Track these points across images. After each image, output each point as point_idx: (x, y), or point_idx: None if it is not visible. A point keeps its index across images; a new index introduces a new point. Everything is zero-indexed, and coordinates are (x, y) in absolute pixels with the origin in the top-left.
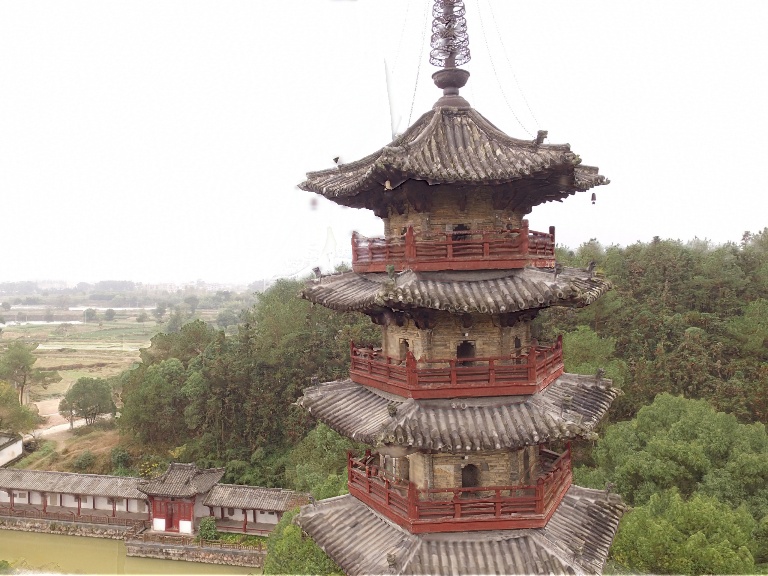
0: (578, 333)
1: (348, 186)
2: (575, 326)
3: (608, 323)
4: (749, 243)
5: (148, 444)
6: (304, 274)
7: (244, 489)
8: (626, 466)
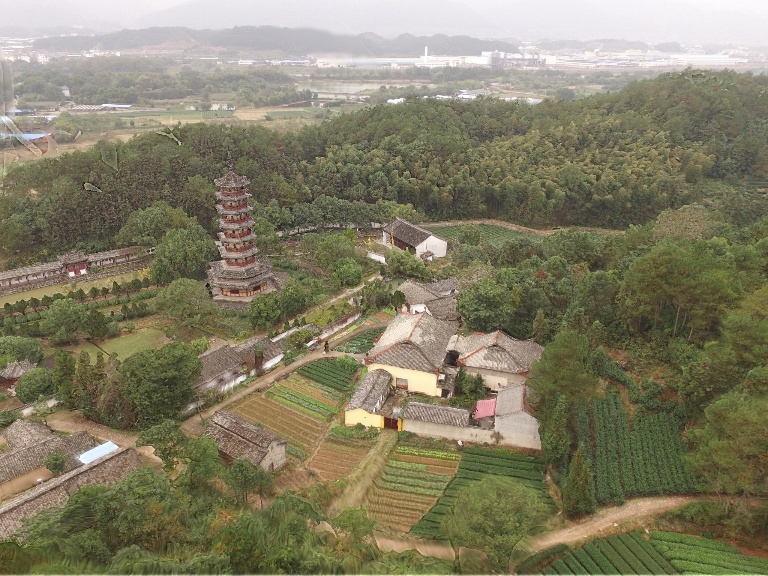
0: (197, 177)
1: (228, 187)
2: (189, 172)
3: (199, 169)
4: (234, 131)
5: (19, 254)
6: (41, 159)
7: (98, 254)
8: None
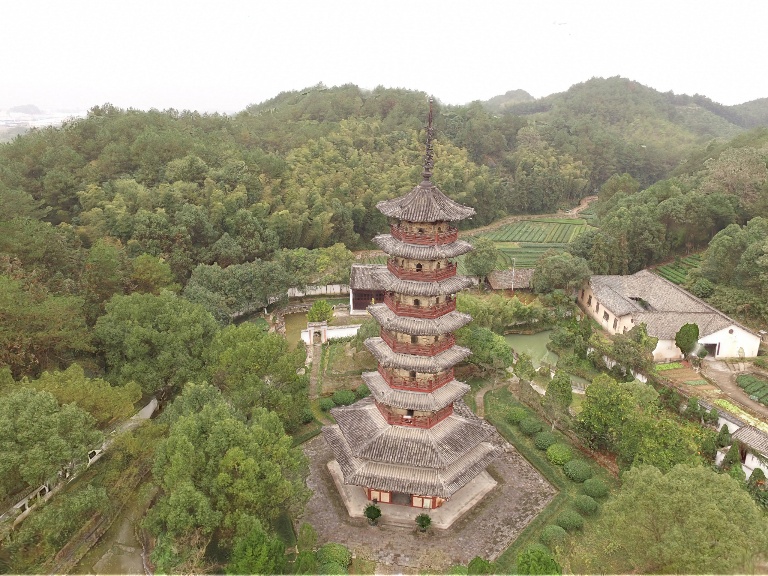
0: None
1: None
2: None
3: None
4: None
5: None
6: None
7: None
8: (181, 340)
